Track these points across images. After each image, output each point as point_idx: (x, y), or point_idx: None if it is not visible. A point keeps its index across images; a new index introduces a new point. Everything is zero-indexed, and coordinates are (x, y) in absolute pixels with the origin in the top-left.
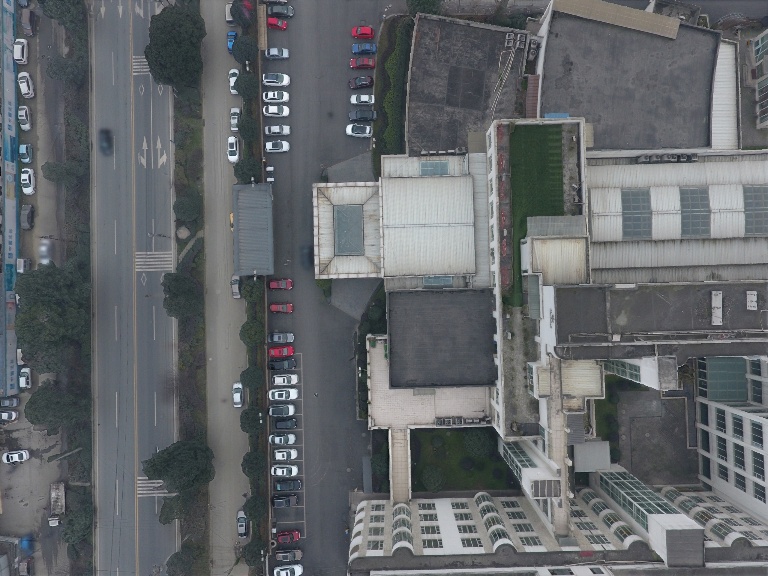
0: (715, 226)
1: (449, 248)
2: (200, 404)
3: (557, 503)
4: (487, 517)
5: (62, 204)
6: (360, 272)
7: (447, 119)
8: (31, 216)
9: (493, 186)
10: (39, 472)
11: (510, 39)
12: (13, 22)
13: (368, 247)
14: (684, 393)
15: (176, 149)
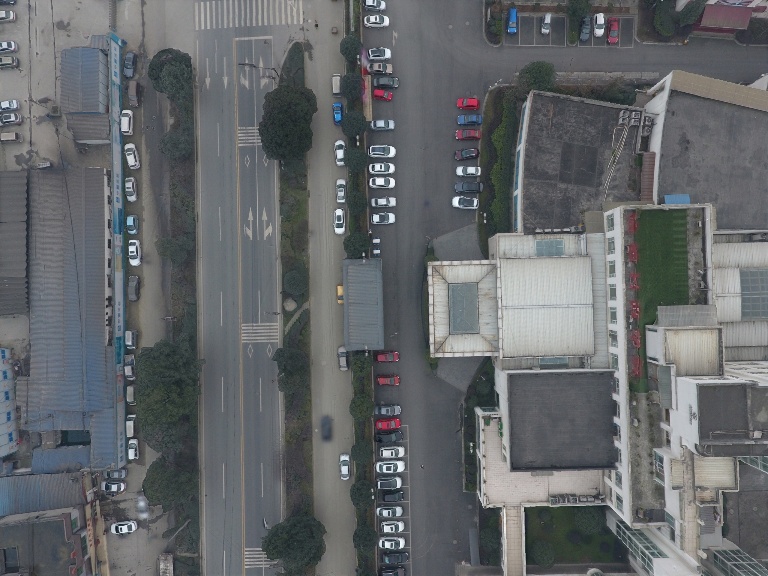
0: None
1: (568, 329)
2: (308, 476)
3: None
4: None
5: (168, 275)
6: (475, 351)
7: (560, 196)
8: (138, 287)
9: (617, 271)
10: (146, 542)
11: (625, 116)
12: (119, 93)
13: (483, 325)
14: None
15: (282, 221)
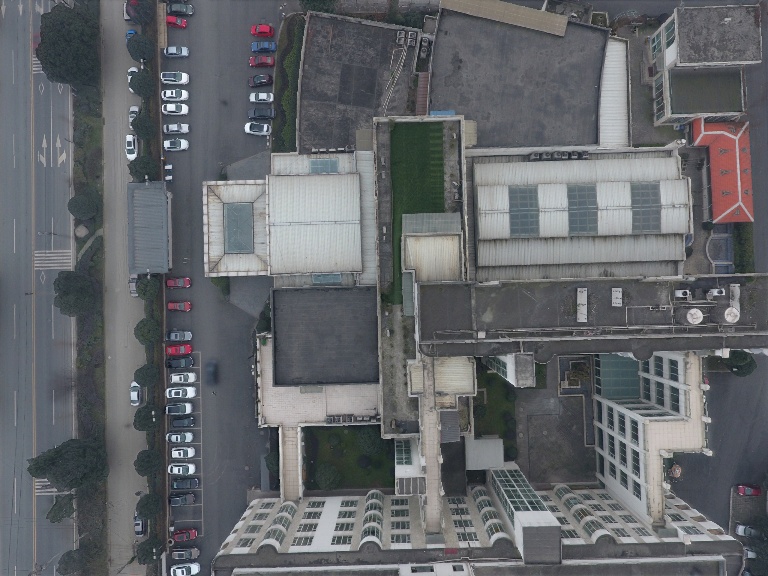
0: (602, 223)
1: (335, 246)
2: (97, 402)
3: (422, 500)
4: (366, 515)
5: None
6: (250, 270)
7: (339, 117)
8: None
9: None
10: None
11: (401, 37)
12: None
13: (258, 245)
14: (582, 391)
15: (75, 147)
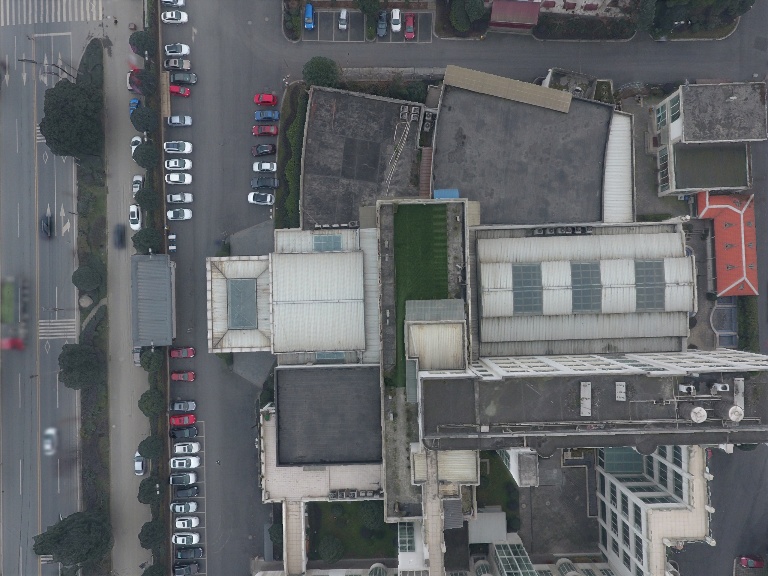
0: (606, 301)
1: (339, 324)
2: (102, 472)
3: None
4: None
5: None
6: (253, 346)
7: (342, 191)
8: None
9: None
10: None
11: (404, 112)
12: None
13: (261, 321)
14: (585, 461)
15: (79, 217)
